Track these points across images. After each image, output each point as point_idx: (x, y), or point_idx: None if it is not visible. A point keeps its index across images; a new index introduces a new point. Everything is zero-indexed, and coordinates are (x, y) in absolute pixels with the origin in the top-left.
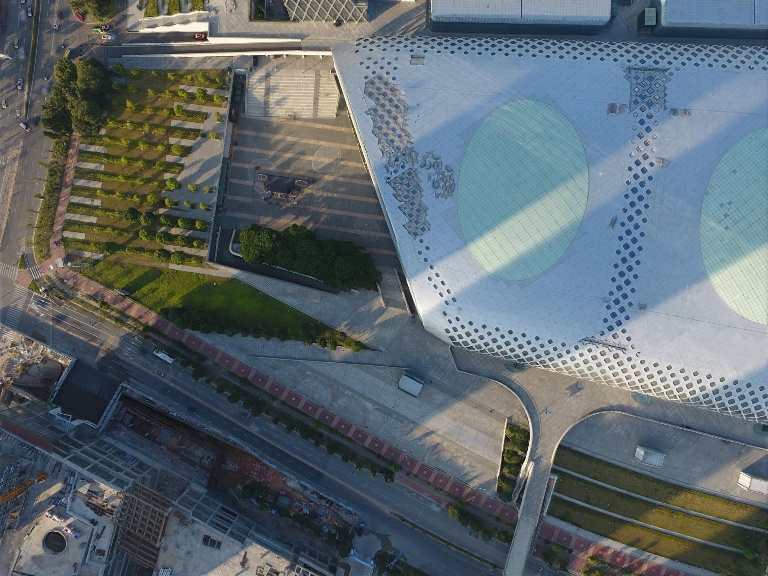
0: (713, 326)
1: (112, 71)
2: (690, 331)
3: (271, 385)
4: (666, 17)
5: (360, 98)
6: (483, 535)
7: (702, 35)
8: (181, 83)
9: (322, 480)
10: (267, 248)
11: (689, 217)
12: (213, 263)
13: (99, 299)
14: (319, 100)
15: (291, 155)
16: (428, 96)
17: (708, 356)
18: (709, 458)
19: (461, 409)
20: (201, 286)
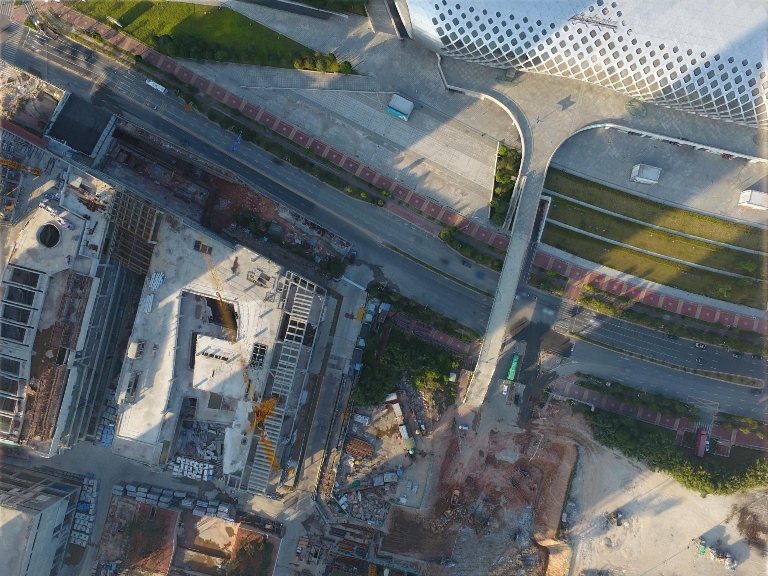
0: None
1: None
2: (682, 1)
3: (262, 116)
4: None
5: None
6: (476, 256)
7: None
8: None
9: (314, 211)
10: None
11: None
12: None
13: (92, 33)
14: None
15: None
16: None
17: (702, 29)
18: (708, 179)
19: (452, 135)
20: (192, 16)
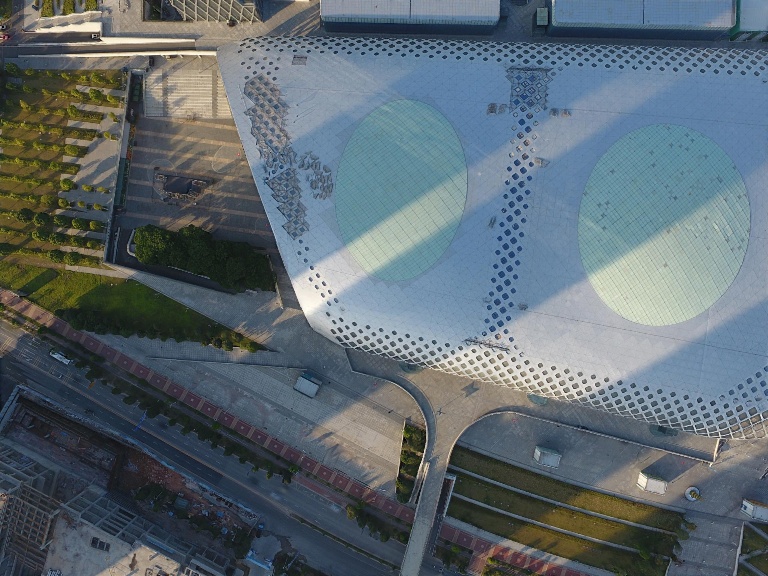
0: (594, 326)
1: (8, 71)
2: (572, 331)
3: (170, 386)
4: (555, 17)
5: (239, 98)
6: (380, 536)
7: (596, 35)
8: (78, 83)
9: (221, 481)
10: (160, 249)
11: (568, 217)
12: (110, 264)
13: None
14: (218, 100)
15: (191, 155)
16: (308, 96)
17: (591, 356)
18: (608, 458)
19: (360, 410)
20: (98, 287)
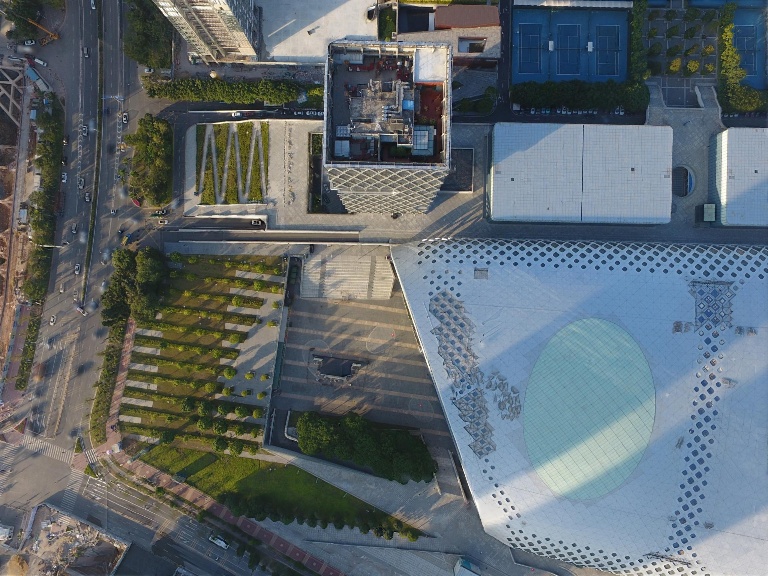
0: None
1: (169, 258)
2: (757, 550)
3: (326, 569)
4: (727, 219)
5: (425, 316)
6: None
7: (760, 228)
8: (237, 269)
9: None
10: (325, 441)
11: (757, 439)
12: (269, 449)
13: (154, 483)
14: (374, 283)
15: (345, 336)
16: (493, 314)
17: None
18: None
19: None
20: (256, 472)
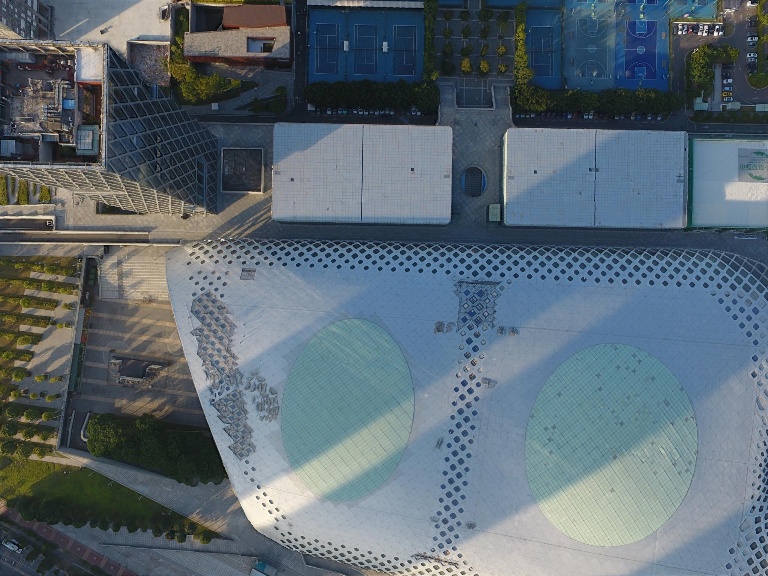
0: (542, 545)
1: None
2: (520, 549)
3: (123, 573)
4: (507, 219)
5: (186, 317)
6: None
7: (550, 228)
8: (32, 270)
9: None
10: (112, 443)
11: (515, 439)
12: (63, 452)
13: None
14: None
15: (146, 338)
16: (255, 315)
17: (540, 573)
18: None
19: None
20: (51, 475)
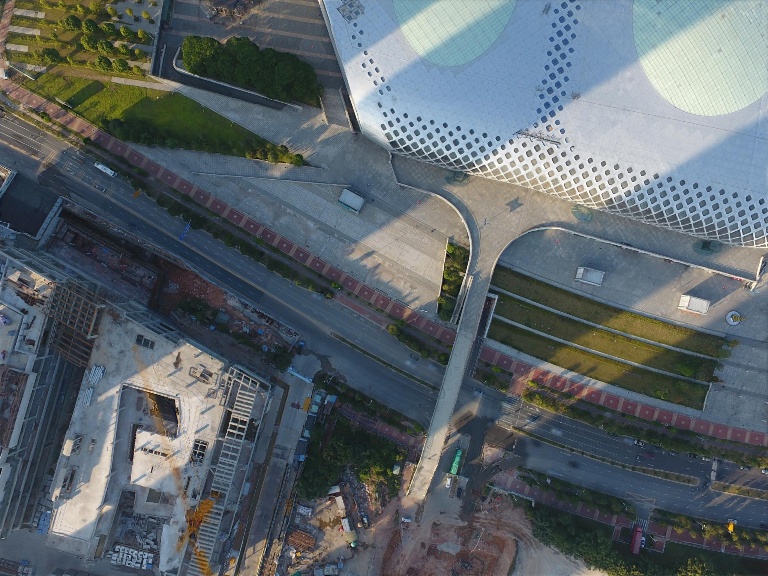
0: (646, 117)
1: None
2: (623, 122)
3: (213, 202)
4: None
5: None
6: (422, 352)
7: None
8: None
9: (263, 299)
10: (208, 55)
11: (622, 4)
12: None
13: (41, 112)
14: None
15: None
16: None
17: (641, 150)
18: (650, 281)
19: (403, 229)
20: (144, 100)
